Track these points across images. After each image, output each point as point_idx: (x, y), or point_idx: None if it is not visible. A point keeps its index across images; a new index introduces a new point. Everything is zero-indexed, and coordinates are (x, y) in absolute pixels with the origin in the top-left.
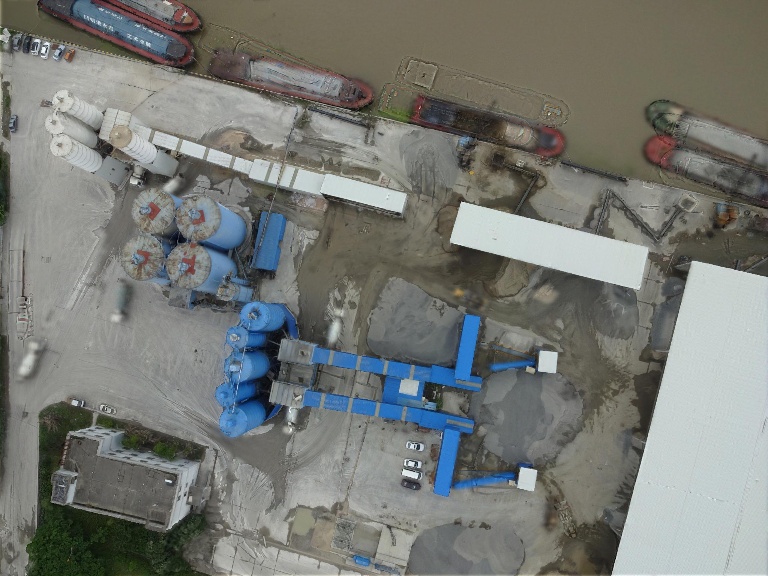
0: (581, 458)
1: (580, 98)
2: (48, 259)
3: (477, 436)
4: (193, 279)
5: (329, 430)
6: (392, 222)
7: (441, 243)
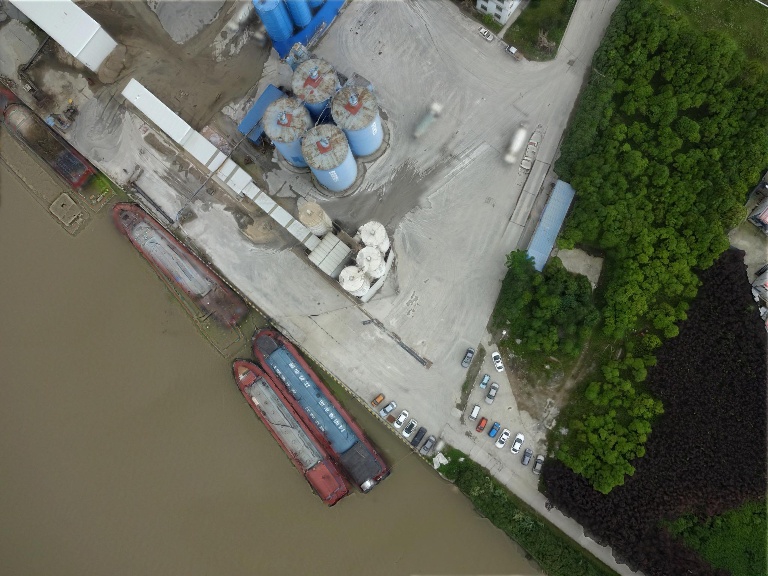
0: None
1: None
2: (488, 201)
3: None
4: (315, 66)
5: None
6: (156, 91)
7: (126, 55)
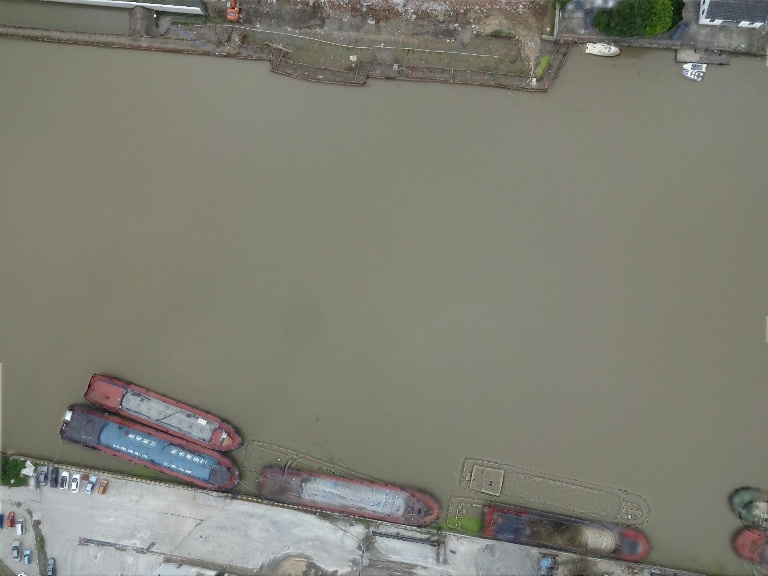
0: None
1: (657, 488)
2: None
3: None
4: None
5: None
6: None
7: None
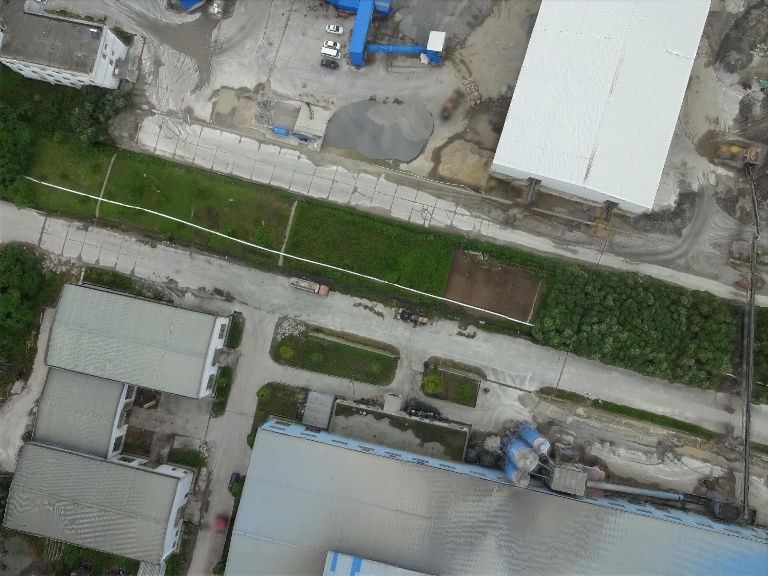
0: (488, 40)
1: None
2: None
3: (393, 21)
4: None
5: (254, 18)
6: None
7: None
